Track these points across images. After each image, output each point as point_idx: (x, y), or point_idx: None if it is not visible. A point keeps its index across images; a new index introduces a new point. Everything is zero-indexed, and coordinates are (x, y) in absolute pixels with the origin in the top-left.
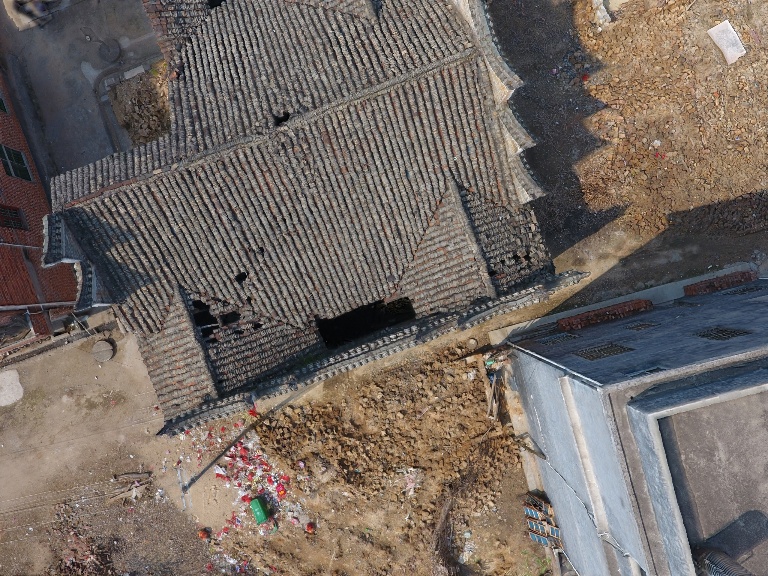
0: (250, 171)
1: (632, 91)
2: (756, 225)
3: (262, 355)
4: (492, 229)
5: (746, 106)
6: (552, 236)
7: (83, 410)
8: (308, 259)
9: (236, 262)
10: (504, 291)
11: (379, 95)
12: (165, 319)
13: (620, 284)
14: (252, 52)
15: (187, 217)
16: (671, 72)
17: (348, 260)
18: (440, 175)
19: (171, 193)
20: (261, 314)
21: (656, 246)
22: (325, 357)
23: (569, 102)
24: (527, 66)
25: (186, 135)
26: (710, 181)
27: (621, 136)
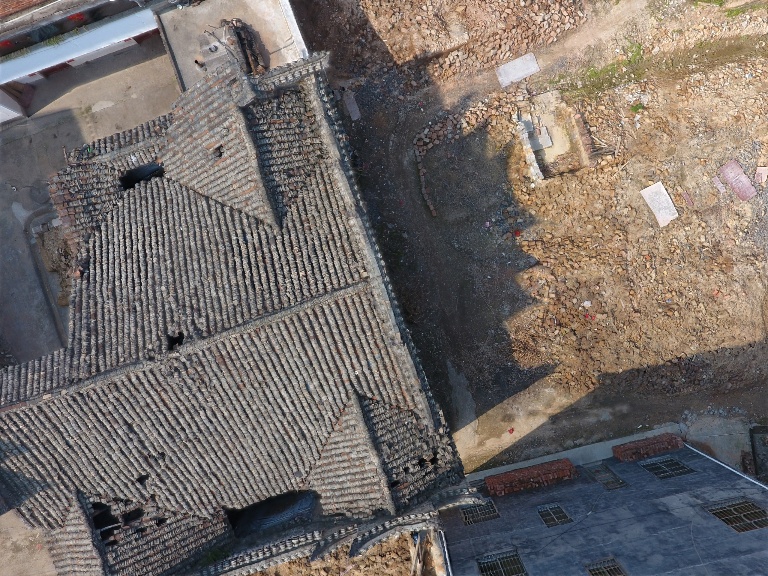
0: (144, 391)
1: (564, 250)
2: (685, 389)
3: (165, 553)
4: (397, 436)
5: (677, 269)
6: (482, 391)
7: (9, 553)
8: (211, 460)
9: (136, 467)
10: (405, 503)
11: (273, 322)
12: (67, 517)
13: (549, 442)
14: (157, 252)
15: (82, 432)
16: (603, 232)
17: (253, 459)
18: (341, 388)
19: (64, 412)
20: (166, 509)
21: (586, 404)
22: (232, 547)
23: (502, 256)
24: (460, 219)
25: (81, 351)
26: (640, 344)
27: (551, 296)
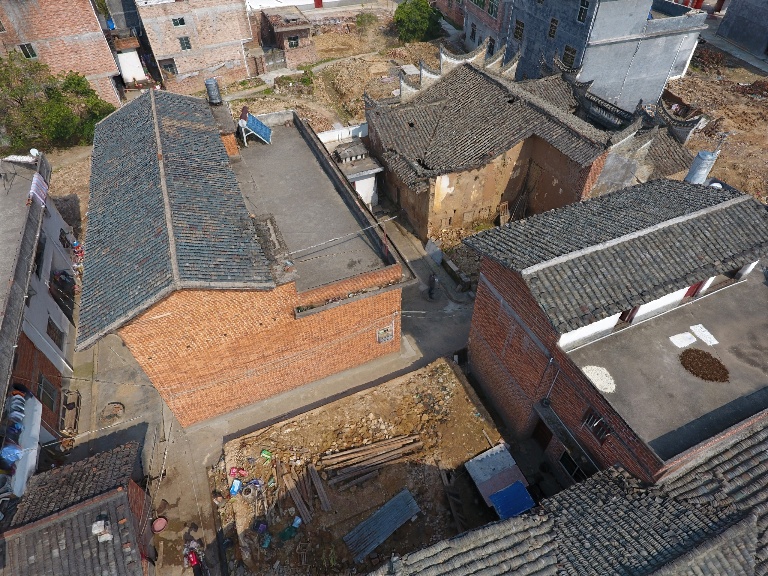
0: None
1: None
2: None
3: None
4: None
5: None
6: None
7: None
8: None
9: None
10: None
11: None
12: None
13: None
14: None
15: None
16: None
17: None
18: None
19: None
20: None
21: None
22: None
23: None
24: None
25: None
26: None
27: None
